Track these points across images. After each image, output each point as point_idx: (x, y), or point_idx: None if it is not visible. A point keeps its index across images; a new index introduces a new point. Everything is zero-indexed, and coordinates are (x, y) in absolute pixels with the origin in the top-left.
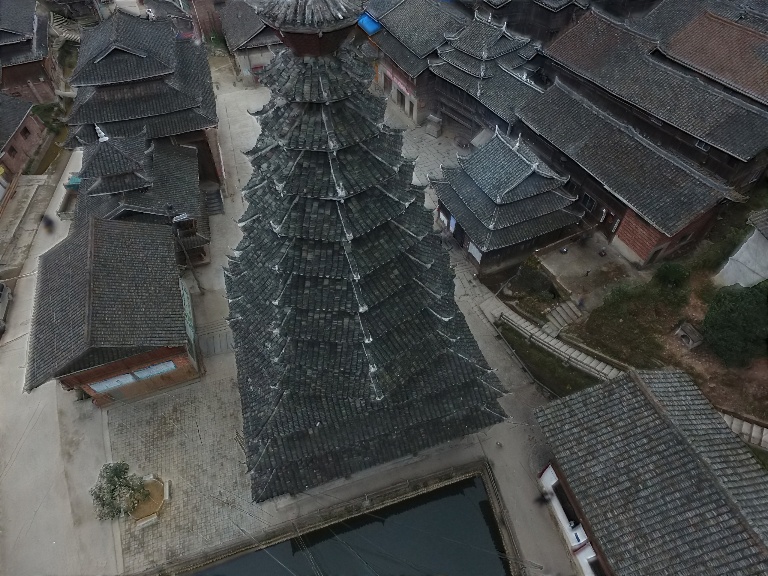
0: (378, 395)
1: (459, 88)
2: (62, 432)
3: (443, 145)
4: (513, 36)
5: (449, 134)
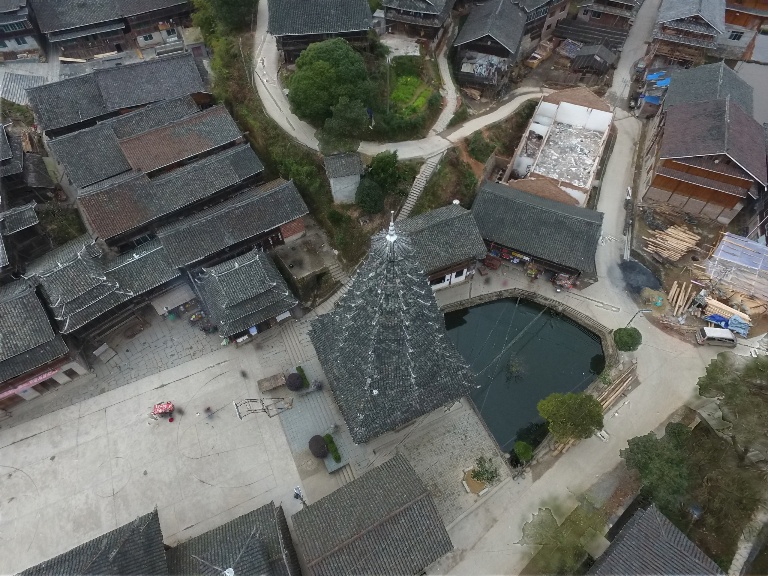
0: None
1: None
2: (450, 569)
3: (130, 348)
4: None
5: (114, 343)
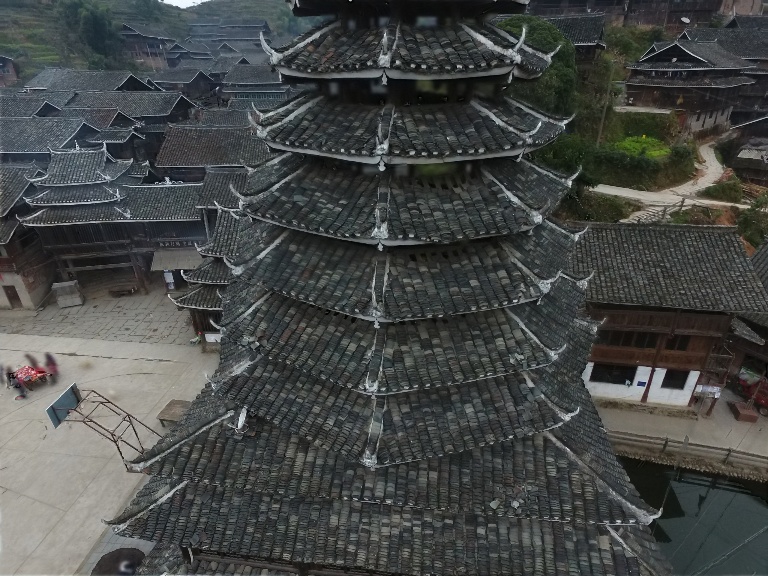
0: (595, 322)
1: (88, 227)
2: None
3: (101, 305)
4: (114, 159)
5: (94, 295)
